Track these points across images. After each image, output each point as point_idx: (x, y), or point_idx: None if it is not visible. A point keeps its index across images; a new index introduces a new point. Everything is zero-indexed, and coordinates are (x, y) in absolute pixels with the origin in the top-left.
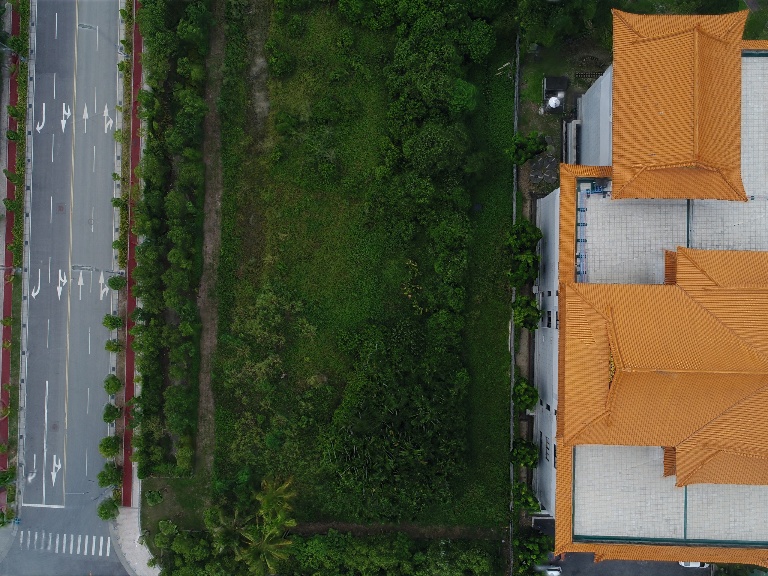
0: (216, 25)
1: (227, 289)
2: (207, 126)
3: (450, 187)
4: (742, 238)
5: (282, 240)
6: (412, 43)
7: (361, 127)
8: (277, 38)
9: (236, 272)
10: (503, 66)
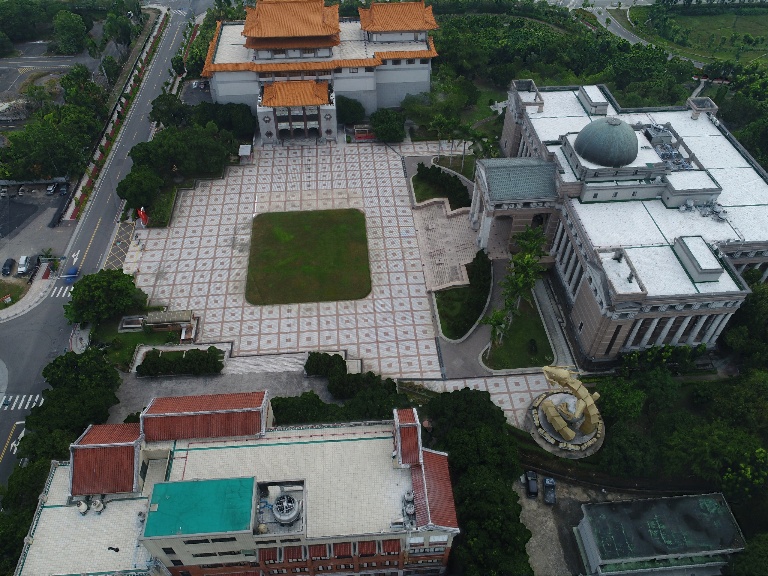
0: None
1: None
2: None
3: None
4: None
5: None
6: None
7: None
8: None
9: None
10: None
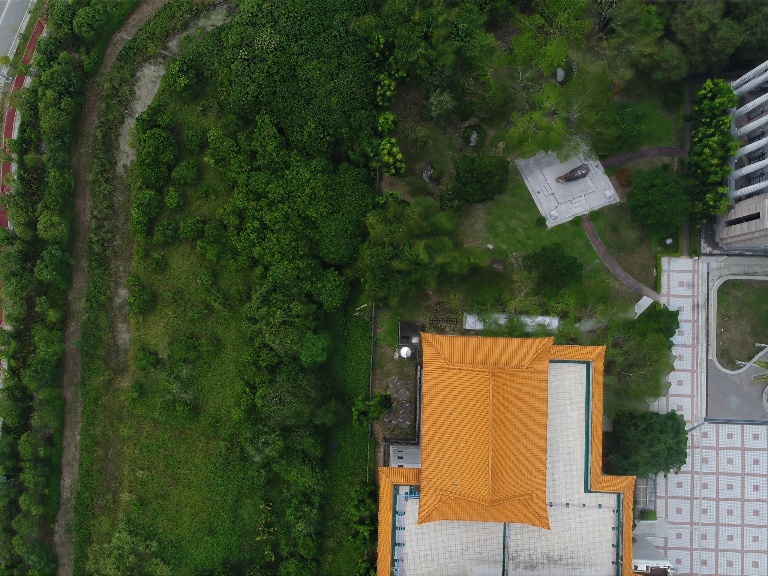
0: (79, 257)
1: (83, 525)
2: (68, 359)
3: (301, 437)
4: (557, 545)
5: (139, 477)
6: (263, 295)
7: (220, 364)
8: (139, 272)
9: (93, 508)
10: (361, 307)
